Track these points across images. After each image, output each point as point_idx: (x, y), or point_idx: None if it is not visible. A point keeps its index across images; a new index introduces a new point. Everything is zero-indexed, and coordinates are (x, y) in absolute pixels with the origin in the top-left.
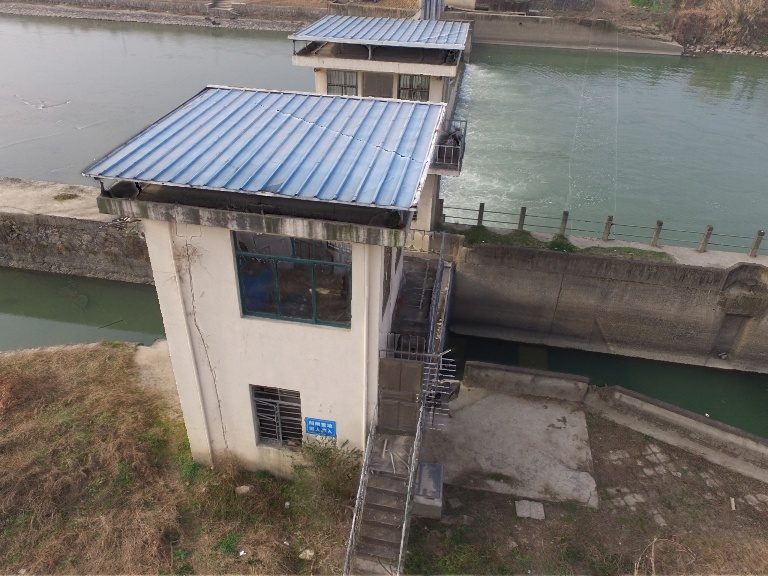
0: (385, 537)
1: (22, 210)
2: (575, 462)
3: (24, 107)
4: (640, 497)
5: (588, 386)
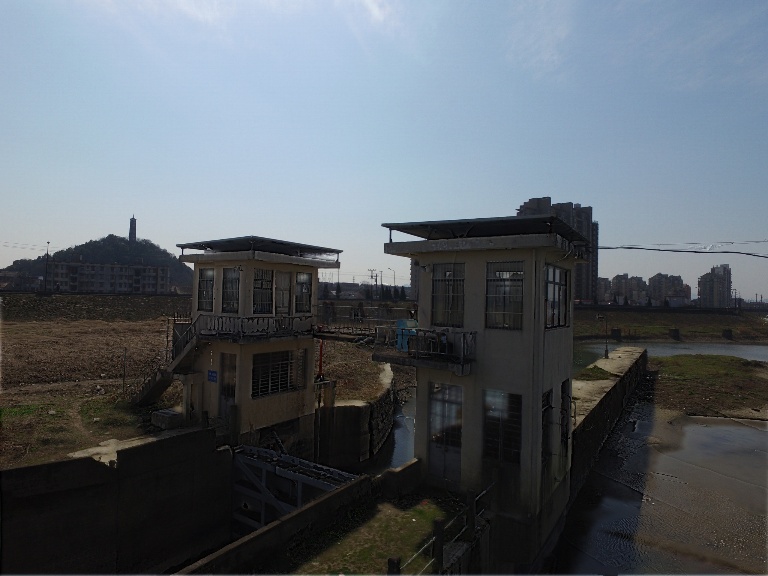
0: None
1: None
2: (96, 457)
3: None
4: None
5: (116, 459)
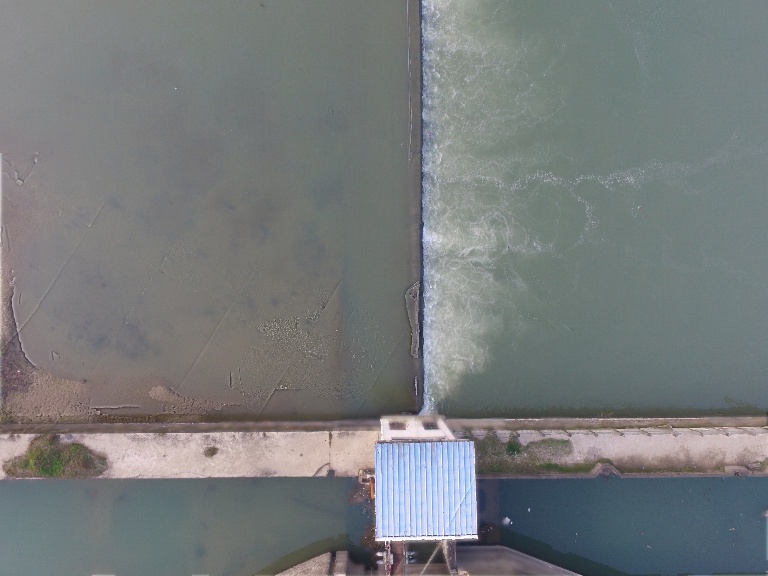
0: None
1: (195, 474)
2: None
3: (0, 182)
4: None
5: None
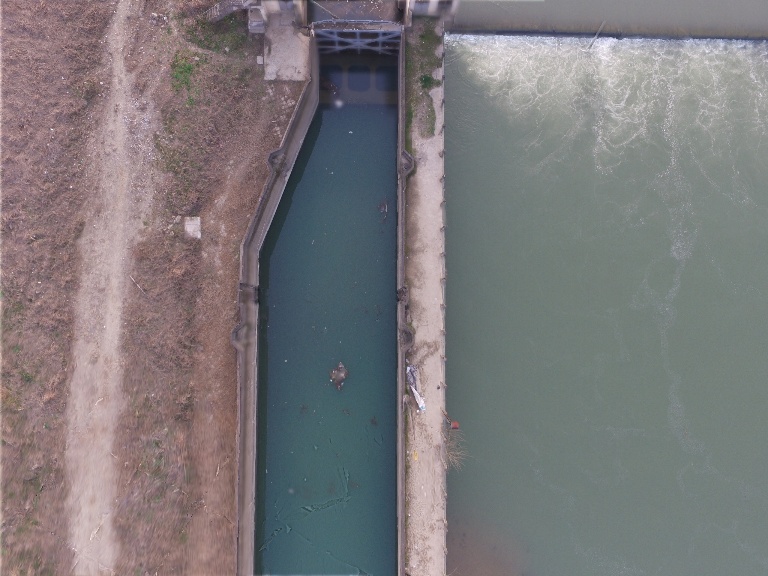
0: (222, 6)
1: None
2: (280, 74)
3: None
4: (272, 94)
5: (310, 77)
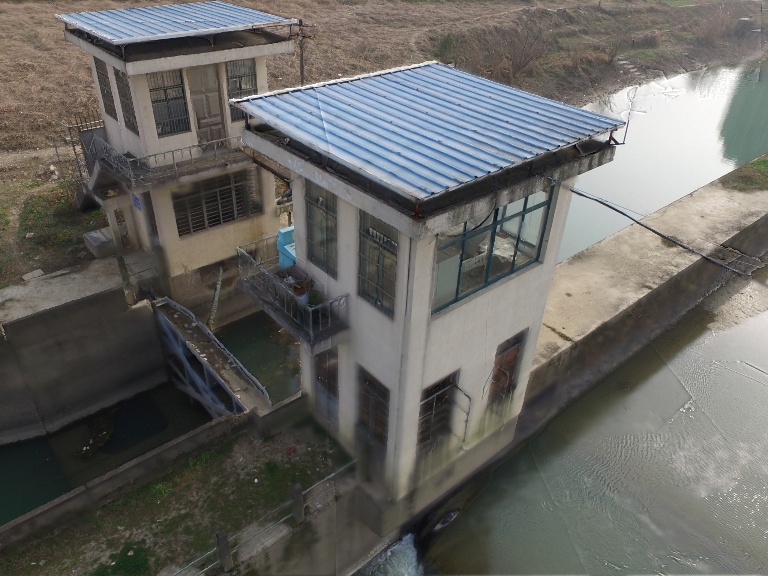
0: None
1: (648, 220)
2: (8, 306)
3: None
4: None
5: (5, 332)
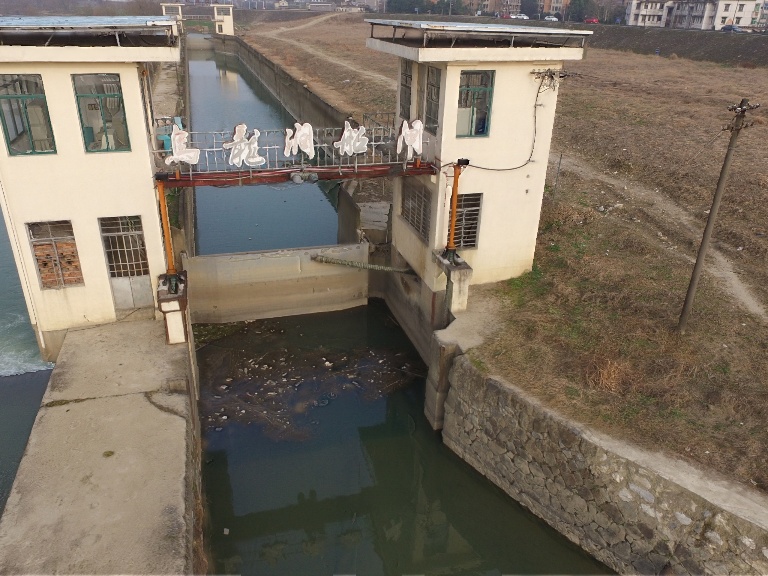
0: None
1: None
2: None
3: None
4: None
5: None
